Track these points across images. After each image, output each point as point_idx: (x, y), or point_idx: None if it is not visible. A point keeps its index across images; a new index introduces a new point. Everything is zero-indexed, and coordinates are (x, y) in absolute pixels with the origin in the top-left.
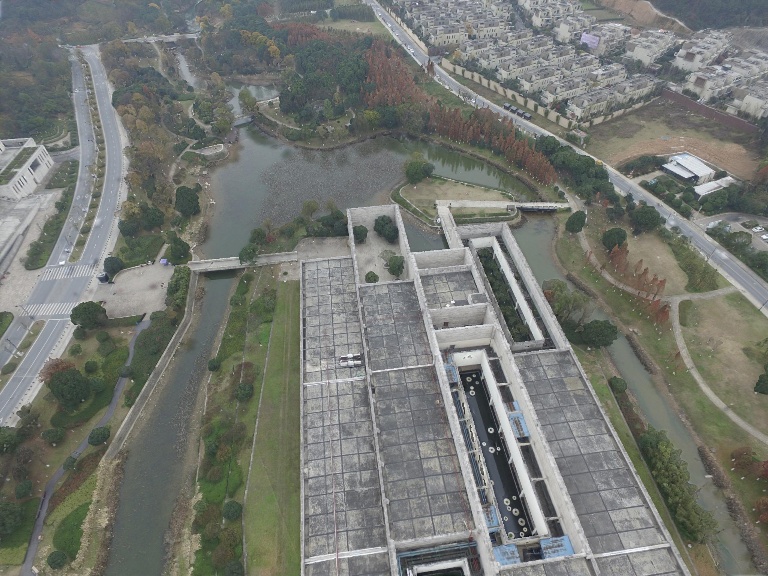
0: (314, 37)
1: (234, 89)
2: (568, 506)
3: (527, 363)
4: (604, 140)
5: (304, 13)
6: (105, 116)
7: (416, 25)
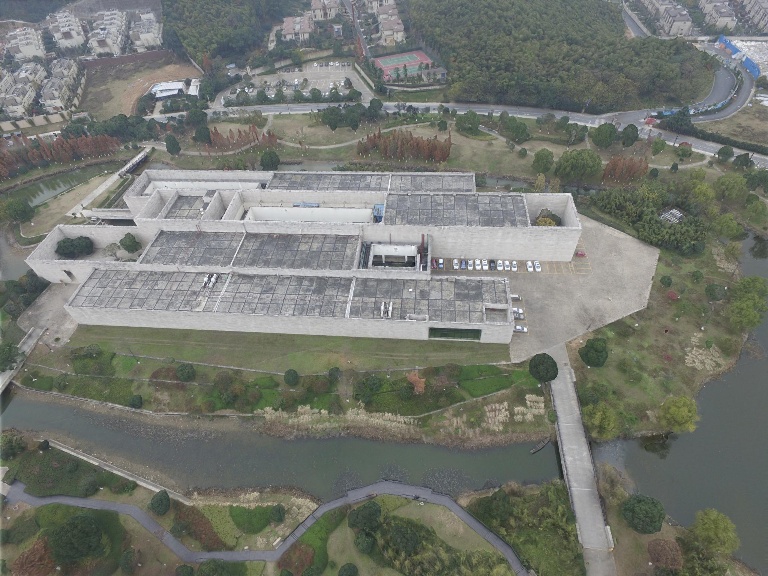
0: None
1: None
2: (363, 192)
3: None
4: (100, 109)
5: None
6: None
7: None
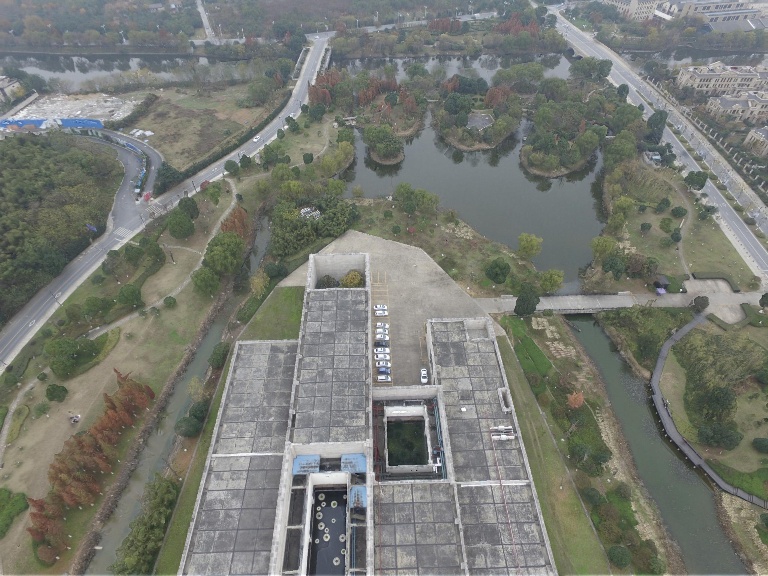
0: None
1: None
2: (285, 483)
3: None
4: None
5: None
6: None
7: None
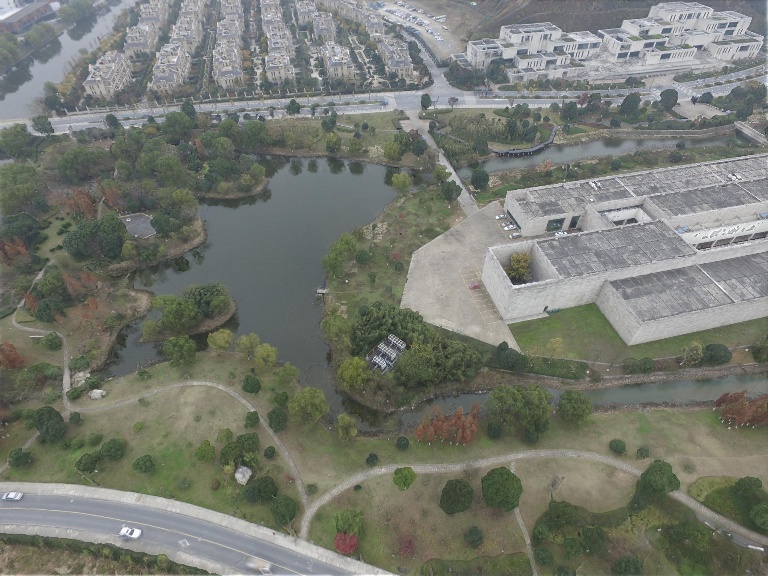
0: None
1: None
2: (722, 248)
3: None
4: None
5: None
6: None
7: None
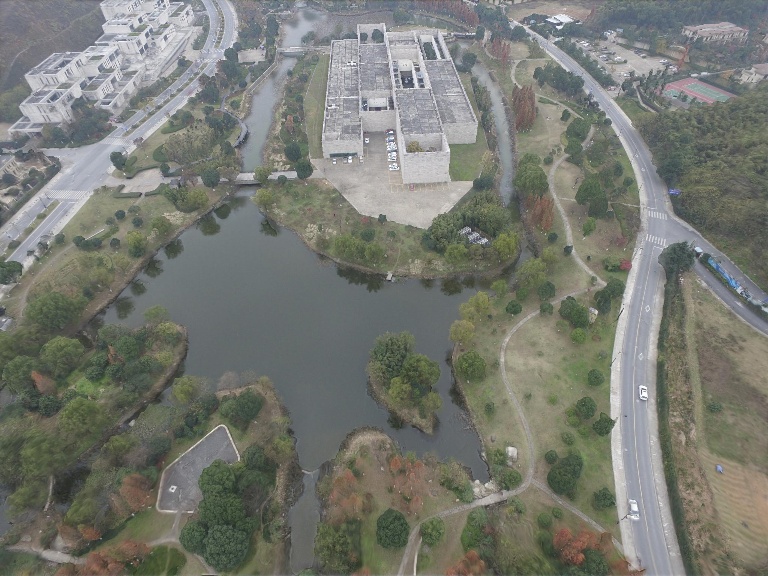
0: None
1: None
2: None
3: (430, 63)
4: (517, 10)
5: None
6: None
7: None
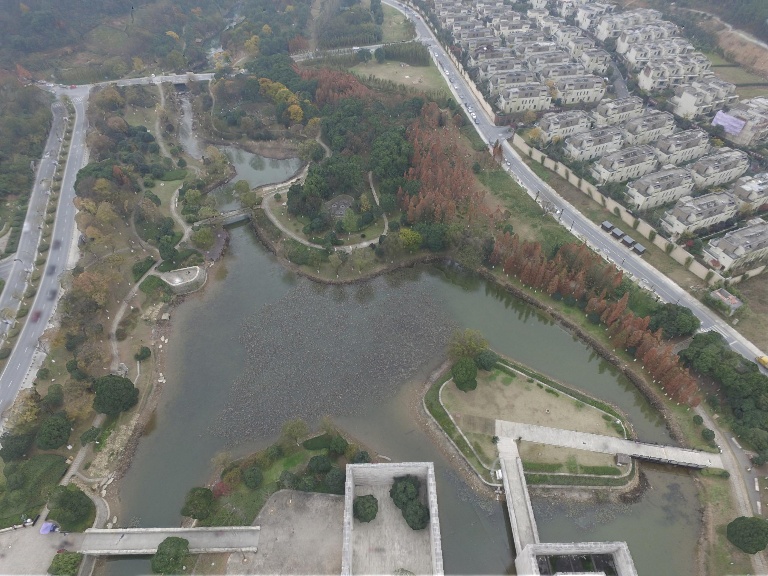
0: (349, 93)
1: (243, 156)
2: None
3: None
4: (767, 313)
5: (344, 51)
6: (65, 202)
7: (482, 78)
